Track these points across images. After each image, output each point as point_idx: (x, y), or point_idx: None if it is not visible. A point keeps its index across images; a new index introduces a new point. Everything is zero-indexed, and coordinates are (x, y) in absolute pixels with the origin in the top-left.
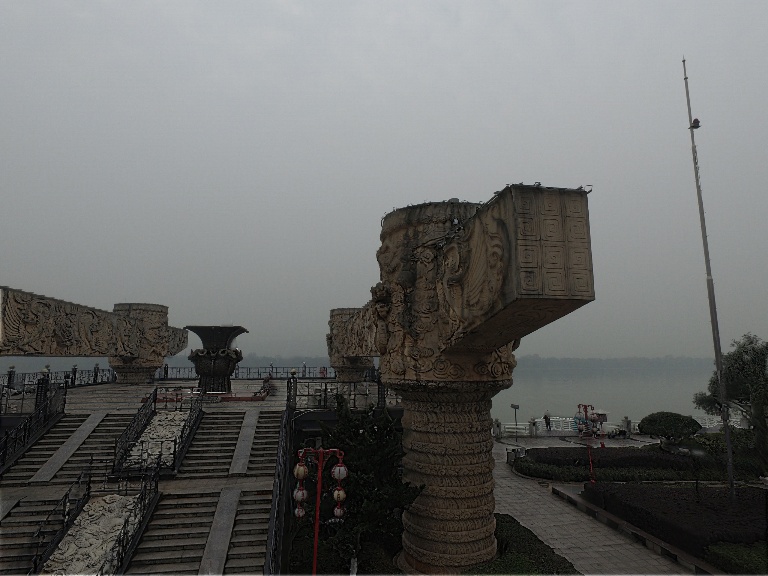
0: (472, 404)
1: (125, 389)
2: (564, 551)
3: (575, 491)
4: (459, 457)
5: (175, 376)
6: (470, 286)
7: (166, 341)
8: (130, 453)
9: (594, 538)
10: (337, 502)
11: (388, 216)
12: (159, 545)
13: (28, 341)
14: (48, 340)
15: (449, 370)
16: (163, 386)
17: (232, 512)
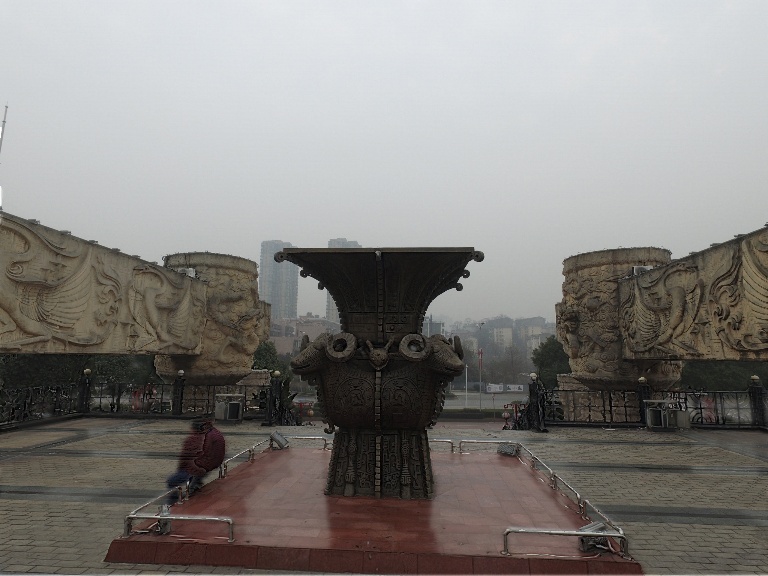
0: None
1: None
2: None
3: None
4: None
5: None
6: None
7: None
8: None
9: None
10: None
11: None
12: None
13: None
14: None
15: None
16: None
17: None
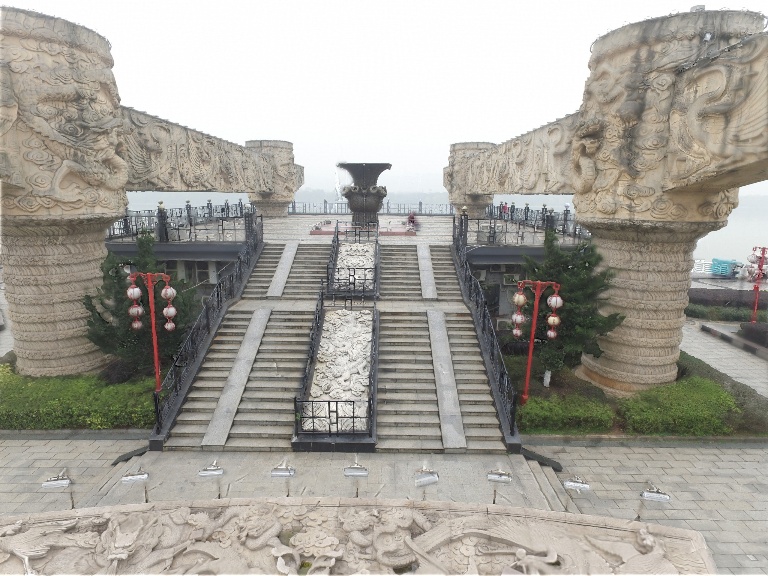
0: (682, 244)
1: (275, 222)
2: None
3: (726, 329)
4: (660, 294)
5: (302, 211)
6: (745, 118)
7: (295, 177)
8: (335, 277)
9: (758, 371)
10: (551, 326)
11: (609, 33)
12: (394, 349)
13: (207, 178)
14: (218, 177)
15: (671, 210)
16: (302, 220)
17: (443, 328)
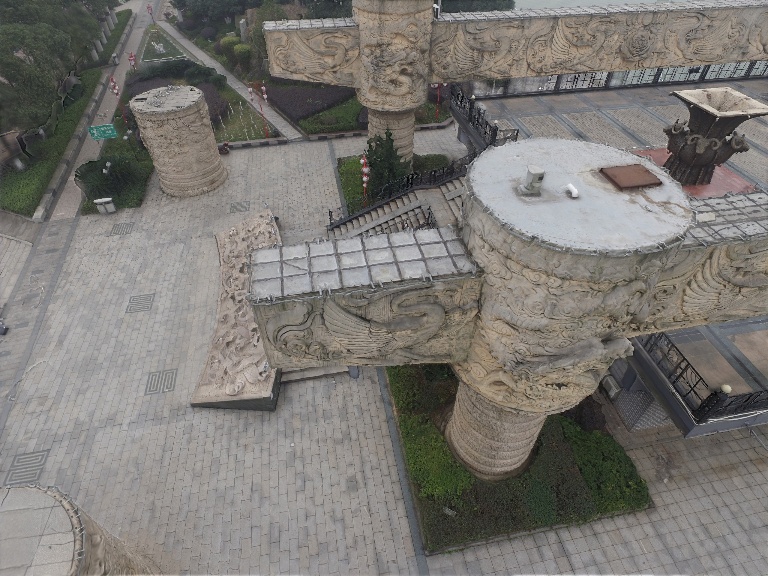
0: None
1: None
2: (567, 574)
3: None
4: None
5: None
6: None
7: None
8: None
9: None
10: None
11: None
12: None
13: (579, 61)
14: (608, 57)
15: None
16: None
17: None
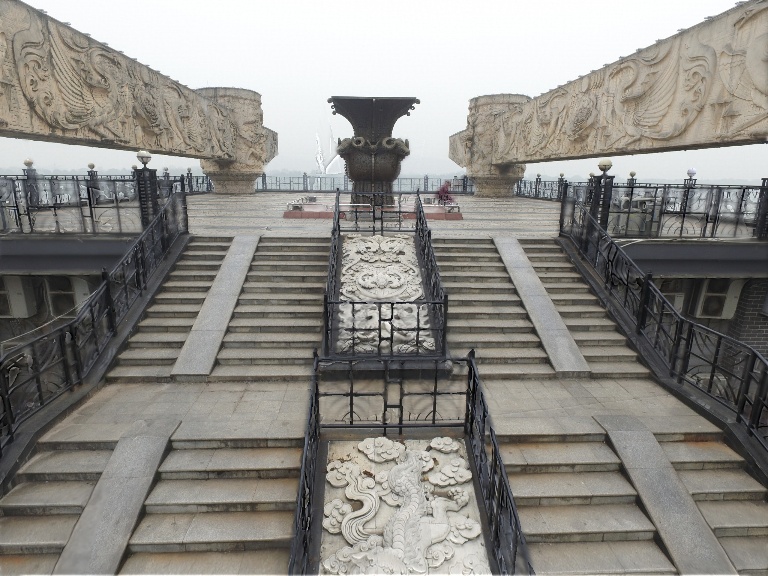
0: None
1: (234, 200)
2: None
3: None
4: None
5: (275, 187)
6: None
7: (264, 141)
8: (340, 317)
9: None
10: None
11: None
12: None
13: (101, 119)
14: (129, 122)
15: None
16: (274, 197)
17: (687, 503)
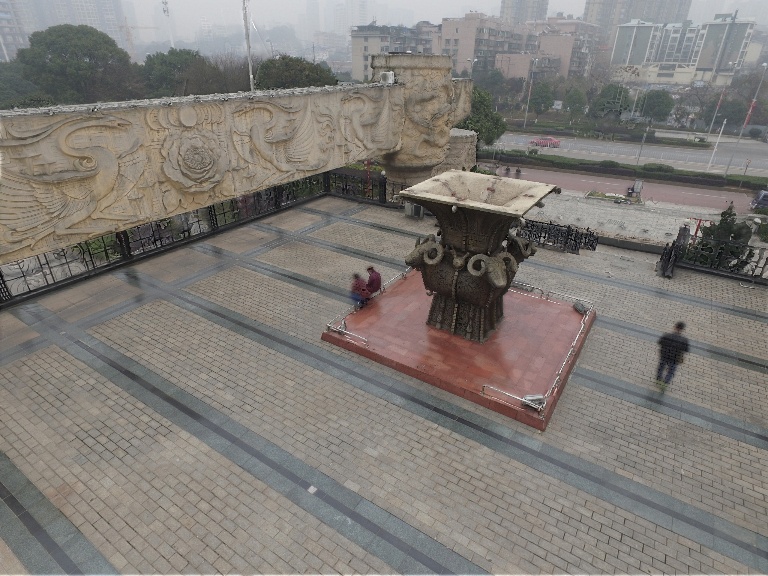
0: None
1: None
2: None
3: None
4: None
5: None
6: None
7: None
8: None
9: None
10: None
11: None
12: None
13: None
14: None
15: None
16: None
17: None
